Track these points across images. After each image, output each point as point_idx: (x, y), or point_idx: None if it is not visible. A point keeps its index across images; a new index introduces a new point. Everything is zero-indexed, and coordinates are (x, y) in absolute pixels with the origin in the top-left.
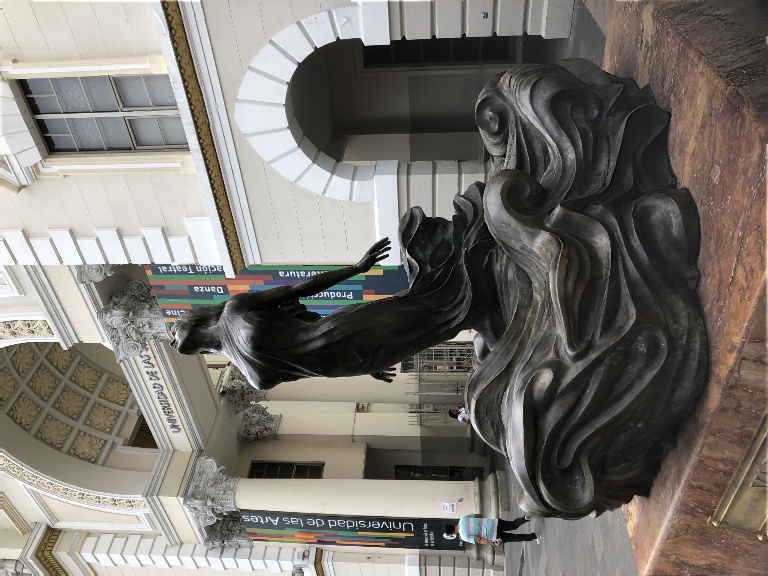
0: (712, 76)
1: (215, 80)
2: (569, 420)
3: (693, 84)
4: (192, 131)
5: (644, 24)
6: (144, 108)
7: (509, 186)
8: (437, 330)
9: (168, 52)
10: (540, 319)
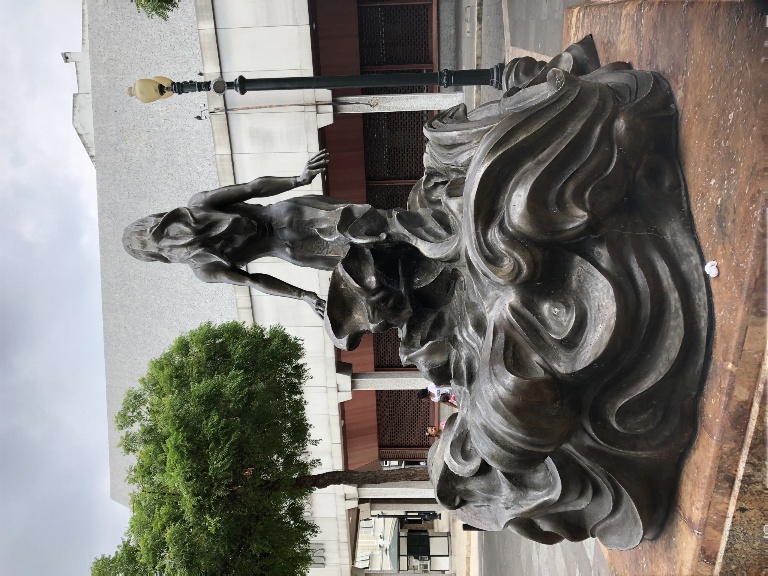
0: None
1: None
2: None
3: None
4: None
5: None
6: None
7: None
8: None
9: None
10: None
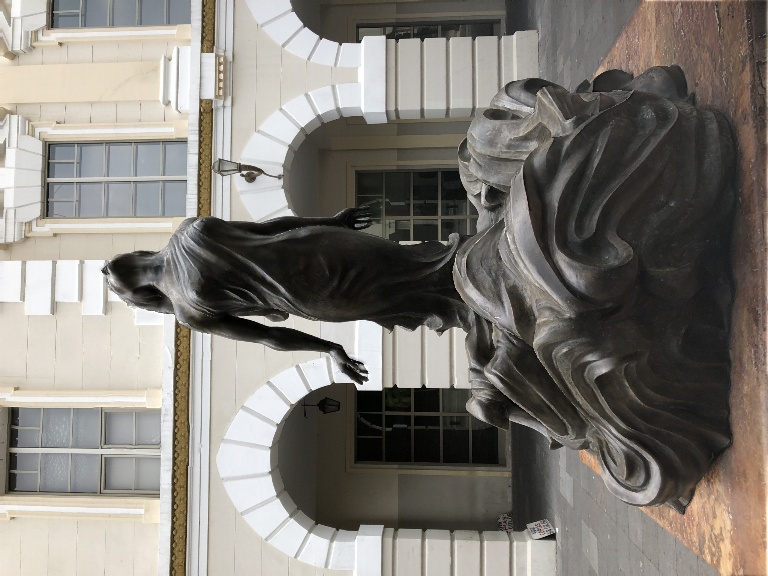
0: None
1: (206, 419)
2: (582, 186)
3: (642, 19)
4: (168, 468)
5: None
6: (126, 446)
7: (491, 112)
8: (420, 271)
9: (168, 384)
10: None
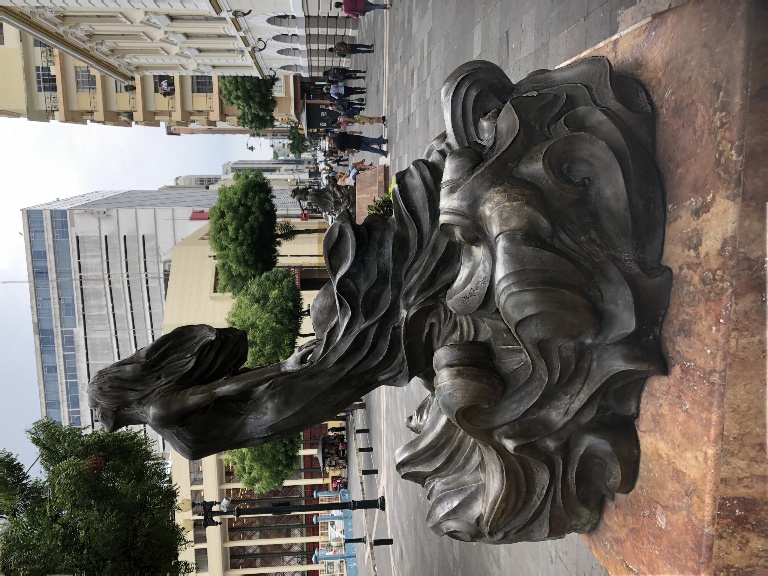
0: (709, 487)
1: None
2: None
3: (696, 435)
4: None
5: (713, 210)
6: None
7: None
8: None
9: None
10: (470, 454)
